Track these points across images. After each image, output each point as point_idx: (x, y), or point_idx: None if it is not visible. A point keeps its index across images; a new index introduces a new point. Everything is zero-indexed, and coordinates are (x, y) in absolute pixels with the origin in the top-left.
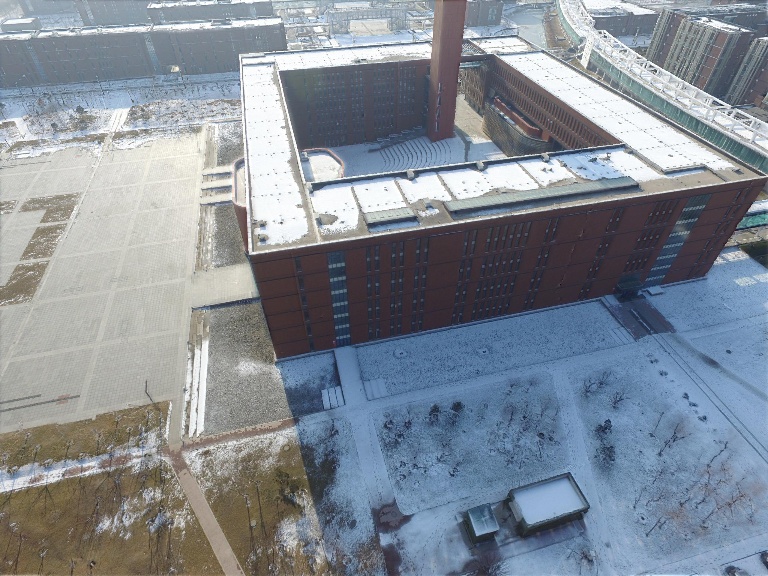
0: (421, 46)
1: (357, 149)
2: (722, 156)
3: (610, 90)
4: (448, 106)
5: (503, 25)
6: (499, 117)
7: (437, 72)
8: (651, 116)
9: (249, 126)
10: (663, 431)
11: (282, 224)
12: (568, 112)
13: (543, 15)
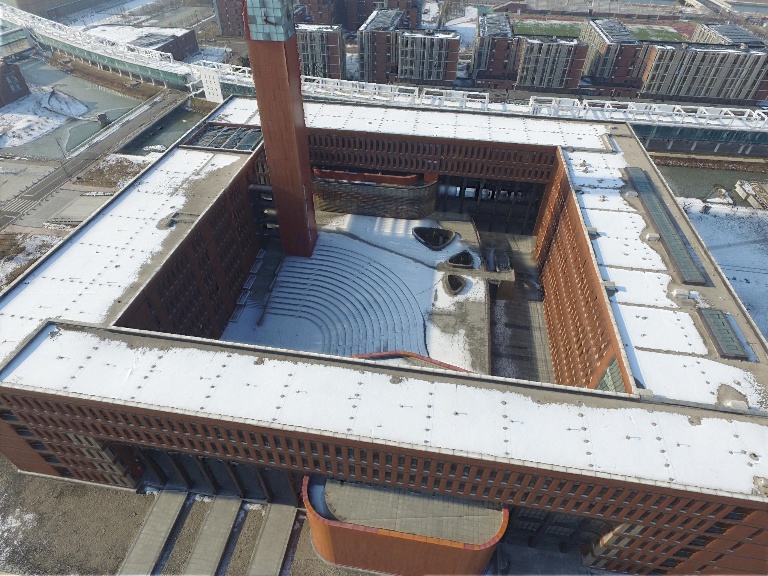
0: (180, 156)
1: (239, 335)
2: (586, 123)
3: (433, 111)
4: (310, 206)
5: (35, 92)
6: (355, 186)
7: (299, 175)
8: (500, 117)
9: (368, 433)
10: (767, 305)
11: (759, 455)
12: (463, 145)
13: (49, 65)
